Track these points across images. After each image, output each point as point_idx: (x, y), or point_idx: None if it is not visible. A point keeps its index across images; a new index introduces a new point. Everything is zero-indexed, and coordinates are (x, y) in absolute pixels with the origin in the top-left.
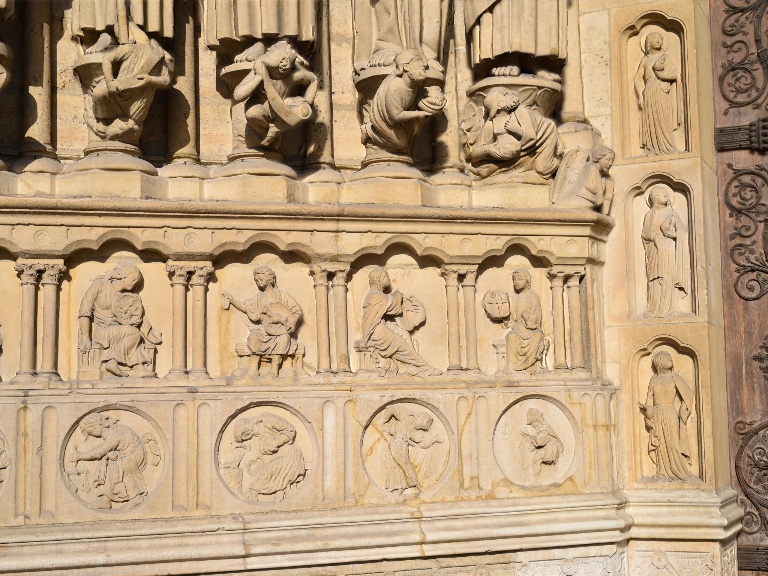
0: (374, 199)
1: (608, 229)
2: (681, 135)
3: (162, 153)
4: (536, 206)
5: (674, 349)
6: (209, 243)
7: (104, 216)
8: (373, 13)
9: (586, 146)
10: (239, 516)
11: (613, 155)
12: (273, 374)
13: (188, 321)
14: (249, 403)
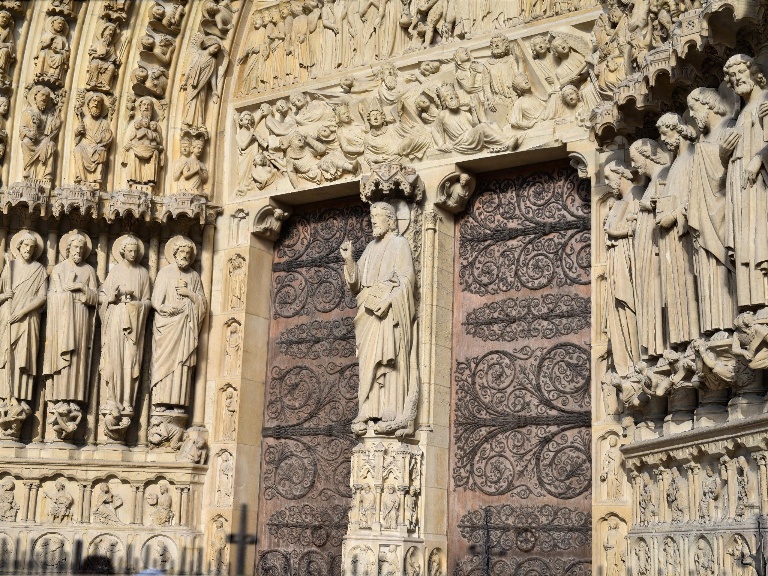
0: (103, 458)
1: (206, 470)
2: None
3: (30, 439)
4: (169, 461)
5: None
6: (38, 474)
7: (1, 464)
8: None
9: (195, 437)
10: (39, 573)
11: (204, 441)
12: (59, 522)
13: (30, 502)
14: (47, 532)
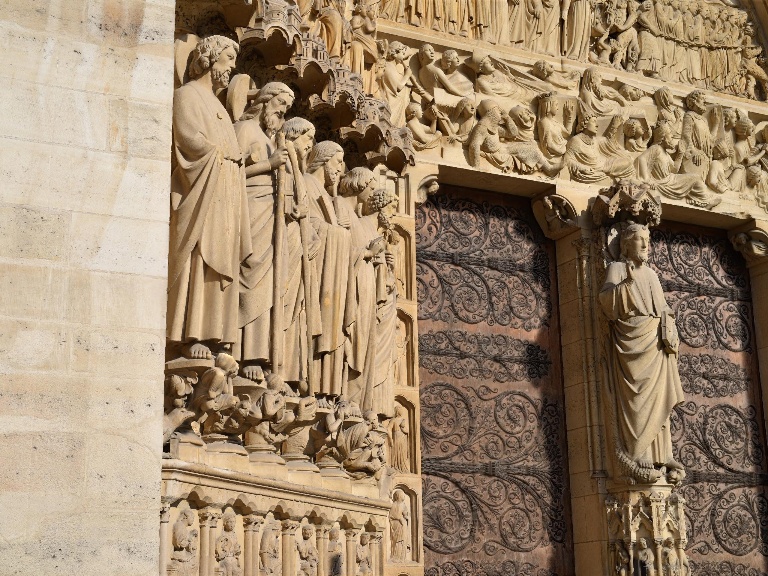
0: (340, 489)
1: None
2: (409, 464)
3: None
4: None
5: None
6: (303, 511)
7: None
8: (347, 384)
9: None
10: None
11: None
12: None
13: None
14: None
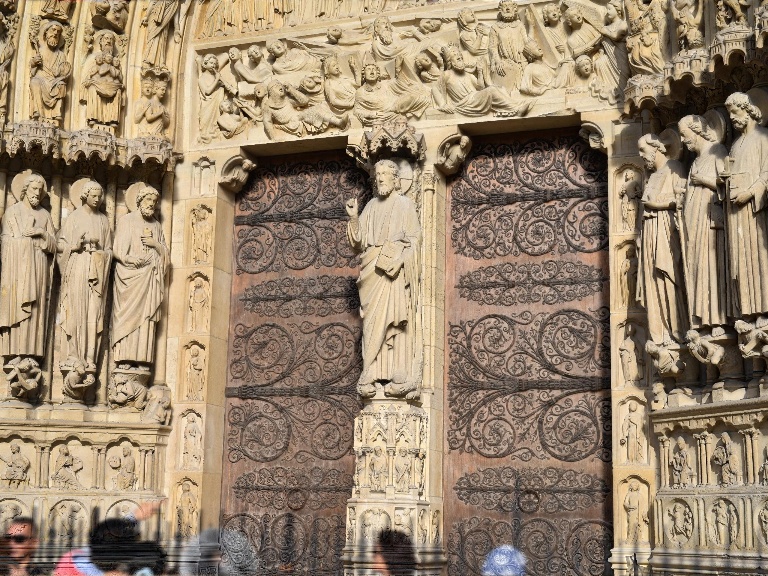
0: (63, 418)
1: (169, 431)
2: (202, 393)
3: None
4: (134, 422)
5: (192, 483)
6: None
7: None
8: (68, 344)
9: (160, 396)
10: None
11: (170, 401)
12: (15, 487)
13: None
14: (4, 498)
